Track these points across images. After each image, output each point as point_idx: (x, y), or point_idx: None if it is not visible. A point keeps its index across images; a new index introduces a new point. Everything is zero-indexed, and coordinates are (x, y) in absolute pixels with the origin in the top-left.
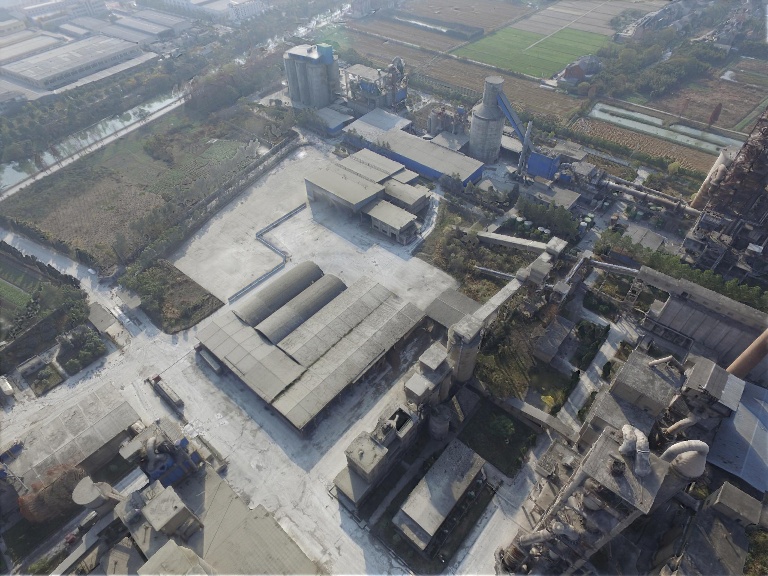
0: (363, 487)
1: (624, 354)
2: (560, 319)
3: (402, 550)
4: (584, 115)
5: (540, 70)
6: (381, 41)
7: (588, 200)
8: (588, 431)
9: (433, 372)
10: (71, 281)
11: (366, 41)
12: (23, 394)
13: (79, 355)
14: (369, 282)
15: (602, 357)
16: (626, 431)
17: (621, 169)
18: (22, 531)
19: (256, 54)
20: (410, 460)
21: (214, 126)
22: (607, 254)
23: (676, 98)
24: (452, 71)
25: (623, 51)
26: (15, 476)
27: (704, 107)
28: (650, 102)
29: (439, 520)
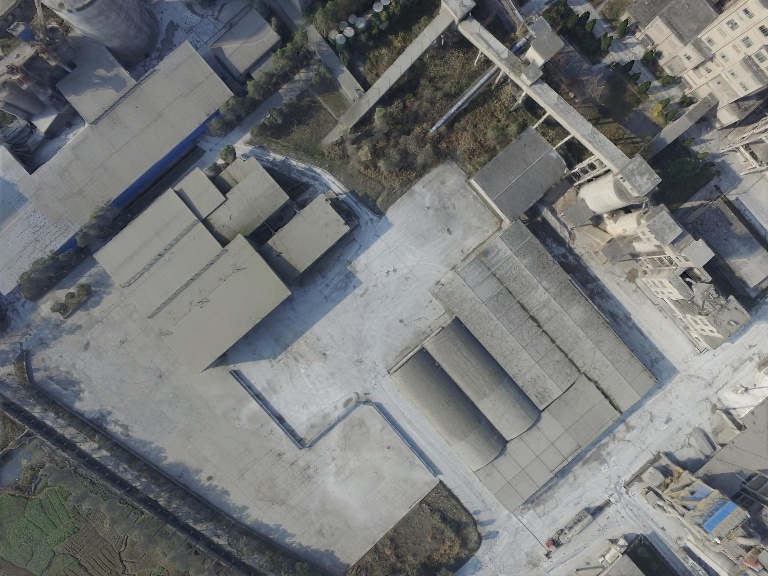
0: None
1: None
2: None
3: None
4: None
5: None
6: None
7: None
8: None
9: None
10: None
11: None
12: None
13: None
14: (453, 287)
15: None
16: None
17: None
18: None
19: None
20: None
21: None
22: None
23: None
24: None
25: None
26: None
27: None
28: None
29: (767, 256)
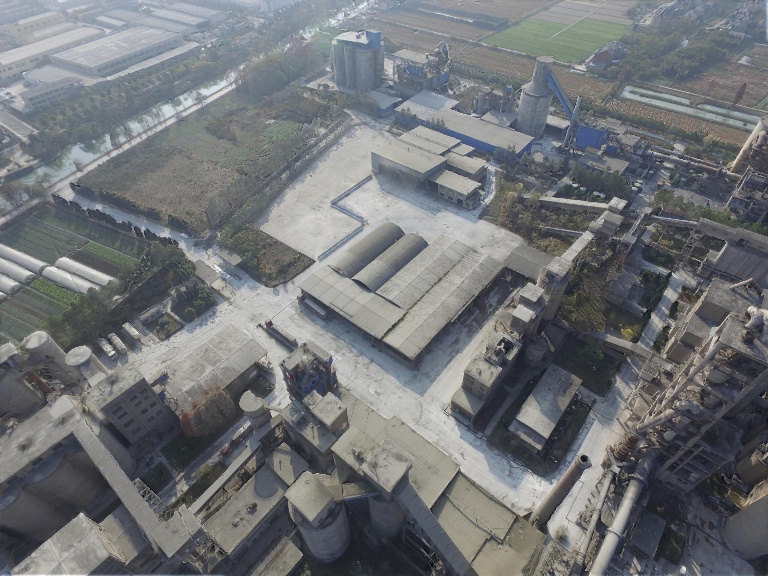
0: (479, 403)
1: (686, 297)
2: (627, 268)
3: (518, 454)
4: (616, 96)
5: (568, 56)
6: (411, 31)
7: (633, 169)
8: (677, 348)
9: (532, 305)
10: (170, 243)
11: (397, 31)
12: (148, 339)
13: (195, 304)
14: (448, 239)
15: (667, 300)
16: (753, 309)
17: (658, 143)
18: (180, 446)
19: (296, 43)
20: (511, 385)
21: (269, 108)
22: (658, 215)
23: (699, 81)
24: (484, 58)
25: (647, 38)
26: (172, 397)
27: (726, 88)
28: (676, 84)
29: (551, 426)
